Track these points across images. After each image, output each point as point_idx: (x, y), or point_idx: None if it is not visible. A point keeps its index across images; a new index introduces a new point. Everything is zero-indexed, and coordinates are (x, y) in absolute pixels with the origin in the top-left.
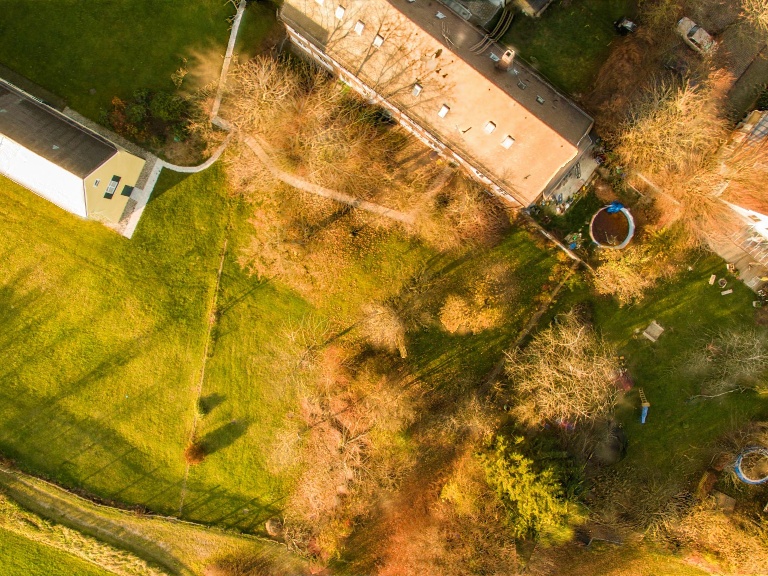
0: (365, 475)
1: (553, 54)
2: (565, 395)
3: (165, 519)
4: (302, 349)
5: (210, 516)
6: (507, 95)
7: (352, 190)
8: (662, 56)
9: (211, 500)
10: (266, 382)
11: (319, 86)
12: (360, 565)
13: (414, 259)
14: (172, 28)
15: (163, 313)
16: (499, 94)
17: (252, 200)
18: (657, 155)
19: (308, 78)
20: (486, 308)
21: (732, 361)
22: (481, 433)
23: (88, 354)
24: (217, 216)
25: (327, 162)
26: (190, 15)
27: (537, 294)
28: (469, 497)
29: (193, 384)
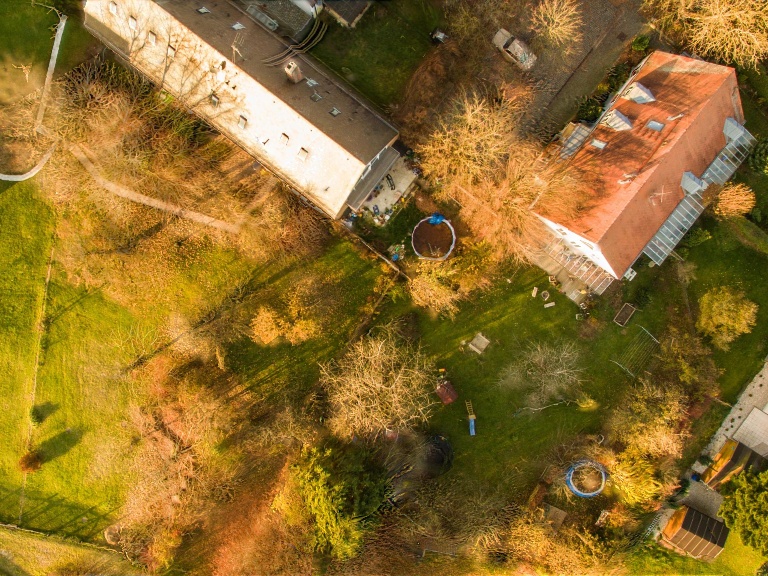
0: (198, 485)
1: (369, 65)
2: (370, 408)
3: (5, 527)
4: (131, 358)
5: (49, 524)
6: (290, 108)
7: (177, 200)
8: (472, 68)
9: (50, 508)
10: (98, 391)
11: (143, 95)
12: (198, 575)
13: (239, 269)
14: None
15: None
16: (283, 106)
17: (78, 209)
18: (475, 167)
19: (132, 87)
20: (299, 320)
21: (547, 374)
22: (301, 444)
23: None
24: (43, 225)
25: (150, 171)
26: (13, 23)
27: (362, 305)
28: (296, 508)
29: (26, 392)
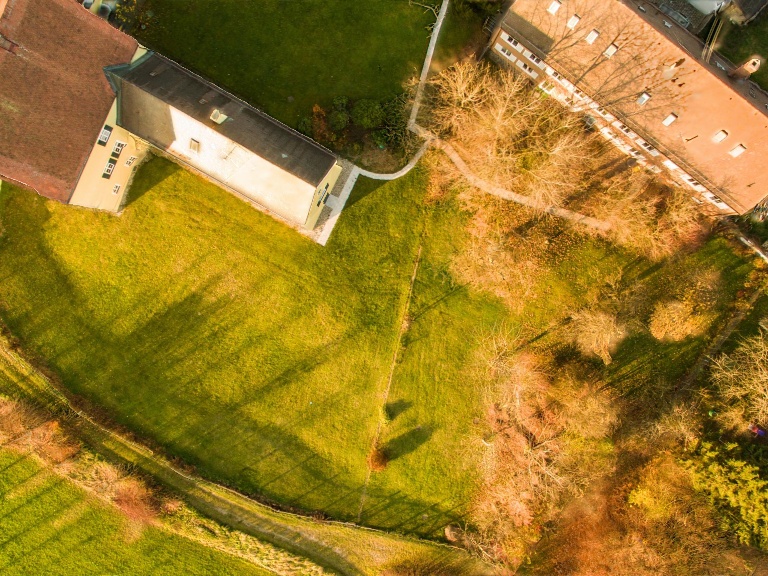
0: (550, 481)
1: None
2: None
3: (343, 525)
4: (493, 355)
5: (389, 522)
6: (750, 104)
7: (549, 197)
8: None
9: (391, 506)
10: (453, 388)
11: (517, 94)
12: (540, 570)
13: (610, 266)
14: (371, 36)
15: (354, 320)
16: (740, 103)
17: (448, 207)
18: None
19: (506, 86)
20: (695, 315)
21: None
22: (681, 439)
23: (274, 361)
24: (412, 223)
25: (526, 169)
26: (390, 23)
27: (732, 300)
28: (661, 502)
29: (379, 390)
